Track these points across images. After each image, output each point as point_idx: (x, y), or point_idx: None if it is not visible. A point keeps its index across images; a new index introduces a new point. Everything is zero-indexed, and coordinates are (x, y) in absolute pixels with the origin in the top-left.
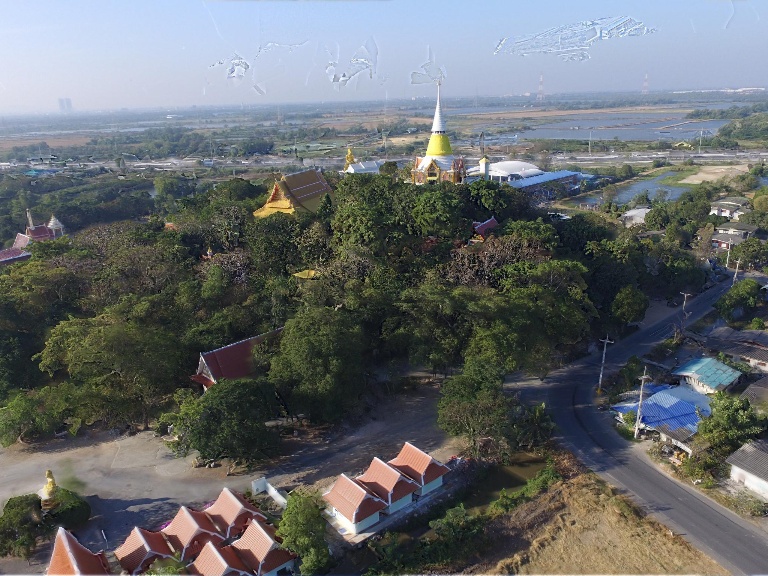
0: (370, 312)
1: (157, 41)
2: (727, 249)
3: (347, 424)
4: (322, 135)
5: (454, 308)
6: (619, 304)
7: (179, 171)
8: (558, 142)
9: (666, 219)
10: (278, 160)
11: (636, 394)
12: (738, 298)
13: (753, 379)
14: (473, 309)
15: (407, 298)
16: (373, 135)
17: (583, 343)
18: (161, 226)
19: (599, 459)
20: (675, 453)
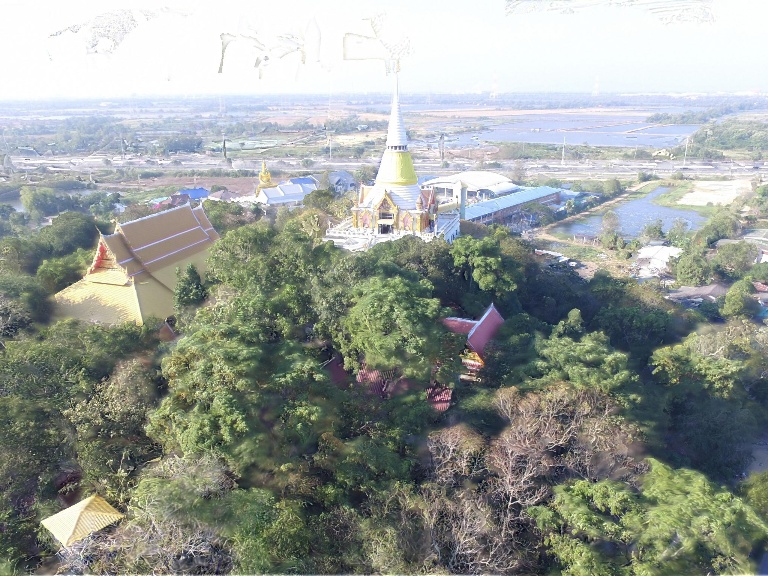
0: None
1: None
2: None
3: None
4: (262, 130)
5: None
6: None
7: (78, 172)
8: (526, 147)
9: (707, 270)
10: (204, 160)
11: None
12: None
13: None
14: None
15: None
16: (319, 132)
17: None
18: None
19: None
20: None
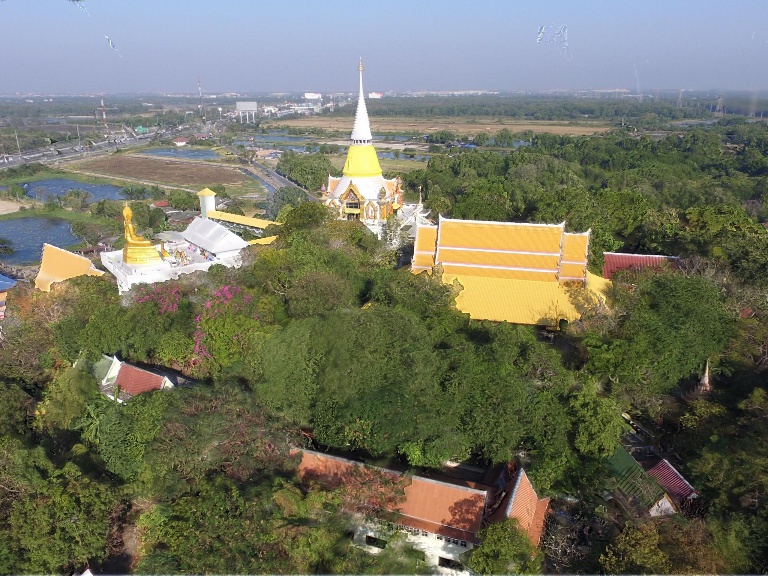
0: None
1: None
2: None
3: None
4: None
5: None
6: None
7: None
8: None
9: None
10: None
11: None
12: None
13: None
14: None
15: None
16: None
17: None
18: None
19: None
20: None
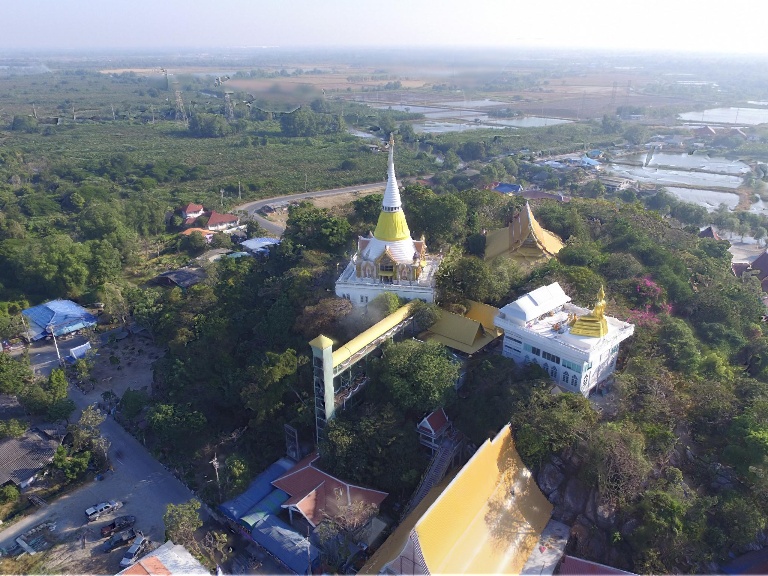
0: None
1: None
2: None
3: None
4: None
5: None
6: None
7: None
8: None
9: None
10: None
11: None
12: None
13: (203, 271)
14: None
15: None
16: None
17: None
18: None
19: None
20: None
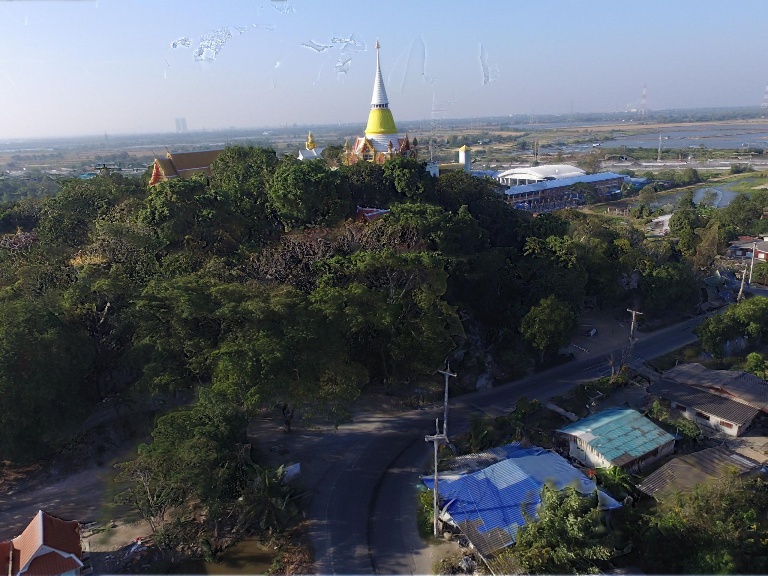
0: (138, 314)
1: (158, 33)
2: (765, 261)
3: (56, 468)
4: None
5: (199, 310)
6: (530, 322)
7: None
8: (627, 148)
9: (695, 223)
10: None
11: (479, 459)
12: (730, 322)
13: (703, 448)
14: (220, 313)
15: (148, 294)
16: (440, 145)
17: (474, 374)
18: (12, 207)
19: (347, 569)
20: (475, 574)
